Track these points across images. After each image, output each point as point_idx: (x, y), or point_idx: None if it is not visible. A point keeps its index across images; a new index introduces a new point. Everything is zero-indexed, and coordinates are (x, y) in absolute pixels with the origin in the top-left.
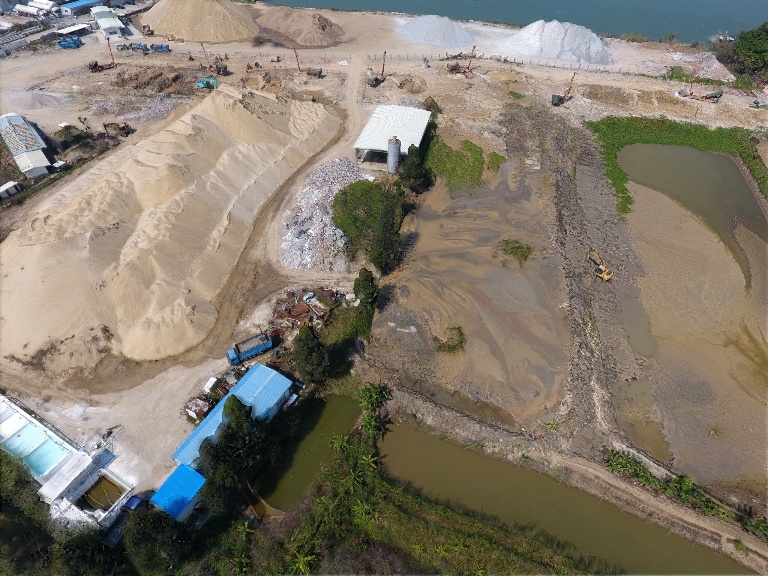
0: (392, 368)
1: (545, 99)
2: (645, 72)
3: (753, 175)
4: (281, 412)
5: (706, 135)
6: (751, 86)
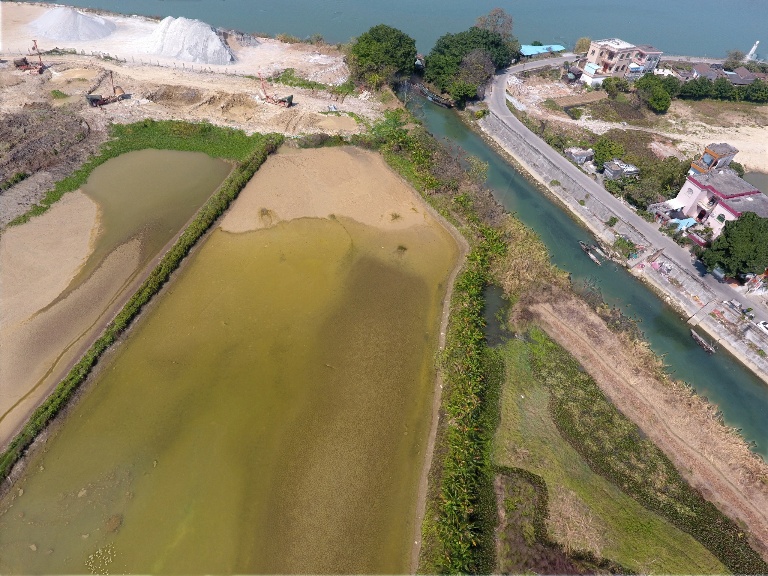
0: None
1: None
2: (257, 74)
3: None
4: None
5: (236, 141)
6: (351, 91)
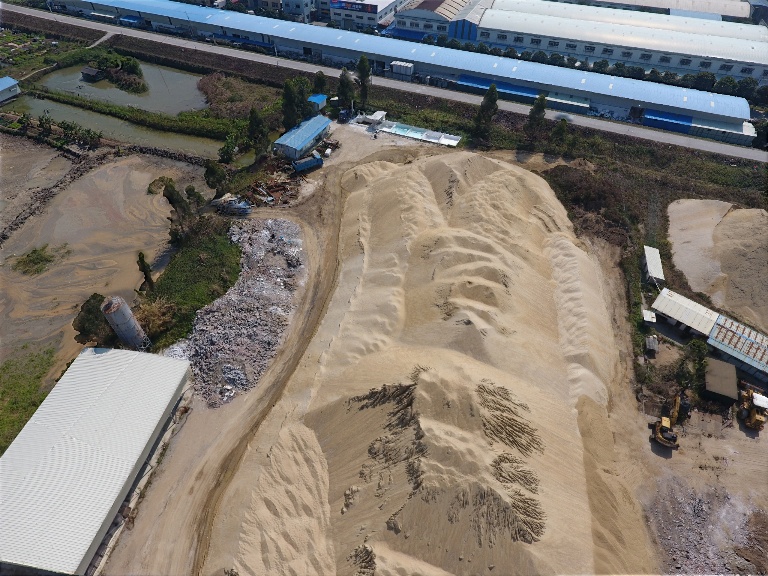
0: None
1: None
2: None
3: None
4: None
5: None
6: None
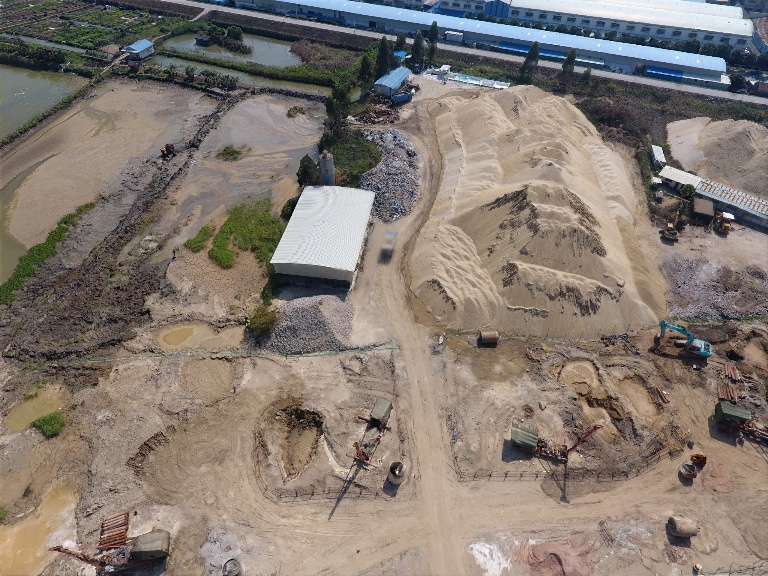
0: None
1: None
2: None
3: None
4: None
5: None
6: None
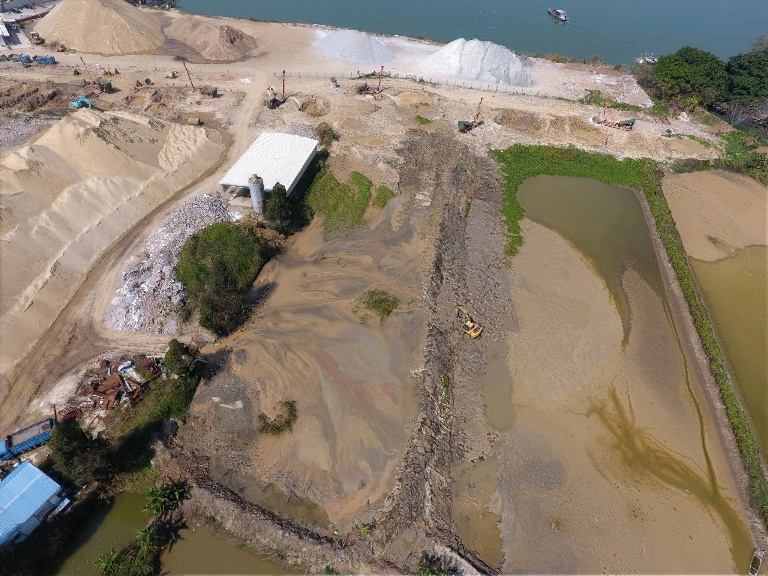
0: (202, 456)
1: (453, 124)
2: (564, 95)
3: (652, 212)
4: (45, 523)
5: (613, 166)
6: (667, 113)
